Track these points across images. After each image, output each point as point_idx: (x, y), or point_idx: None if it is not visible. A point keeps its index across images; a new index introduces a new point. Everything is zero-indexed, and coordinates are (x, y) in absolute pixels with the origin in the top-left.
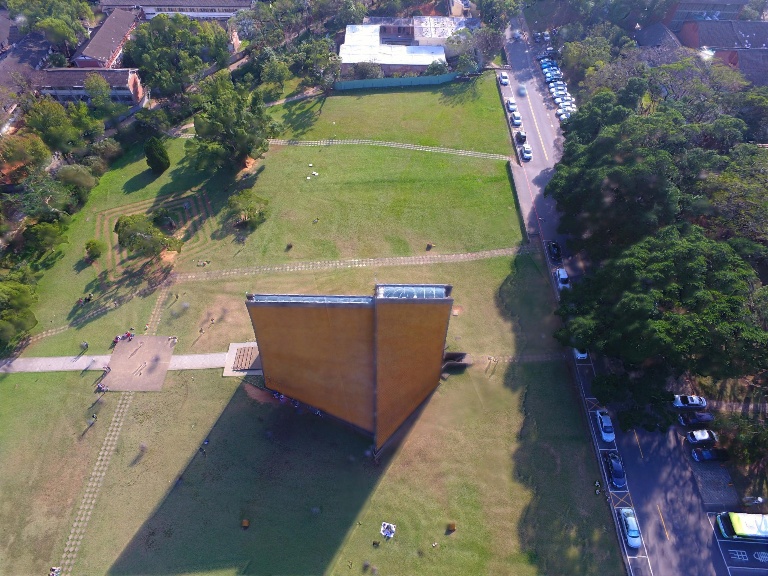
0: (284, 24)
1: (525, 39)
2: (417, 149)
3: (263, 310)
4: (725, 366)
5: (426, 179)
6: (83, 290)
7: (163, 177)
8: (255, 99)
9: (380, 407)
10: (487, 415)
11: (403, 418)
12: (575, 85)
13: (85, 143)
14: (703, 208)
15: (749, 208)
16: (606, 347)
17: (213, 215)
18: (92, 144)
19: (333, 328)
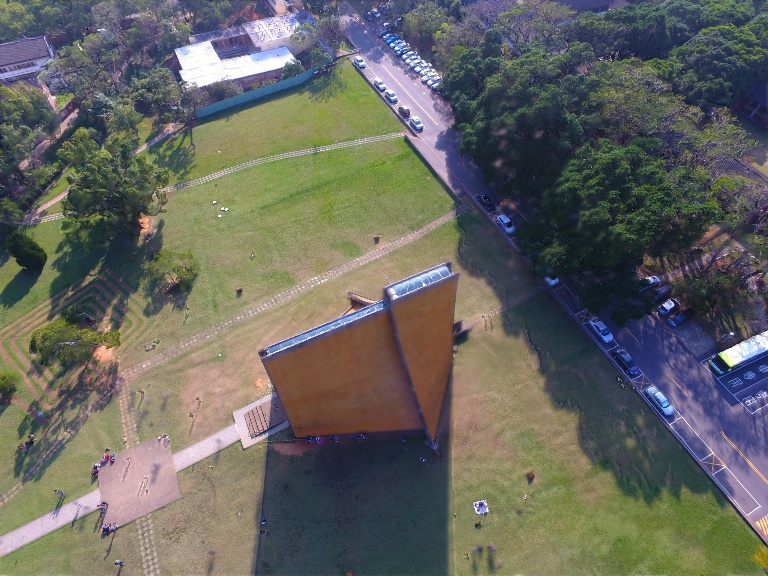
0: (104, 65)
1: (358, 21)
2: (314, 152)
3: (280, 360)
4: (679, 241)
5: (339, 177)
6: (17, 435)
7: (46, 273)
8: (124, 152)
9: (422, 402)
10: (507, 366)
11: (440, 403)
12: (424, 51)
13: None
14: (598, 123)
15: (634, 111)
16: (581, 264)
17: (133, 291)
18: None
19: (353, 348)
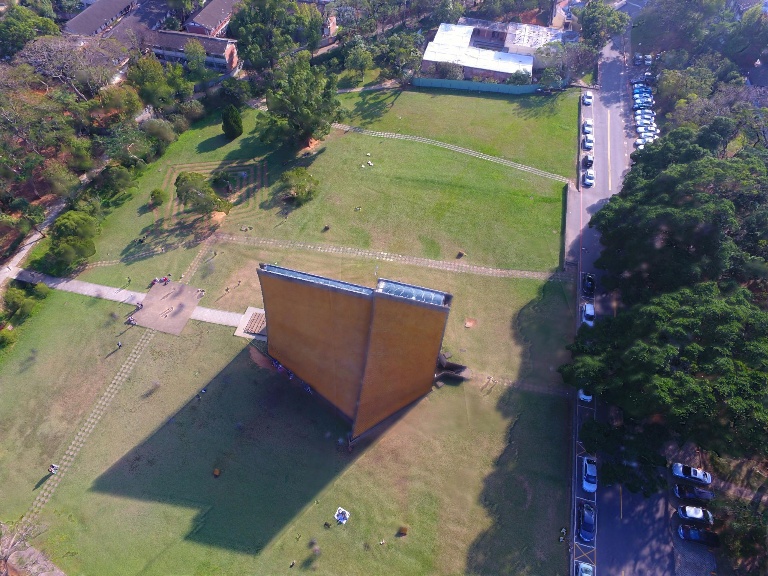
0: (379, 15)
1: (624, 60)
2: (476, 156)
3: (272, 280)
4: (727, 444)
5: (477, 187)
6: (140, 232)
7: (233, 143)
8: (329, 83)
9: (364, 398)
10: (470, 433)
11: (386, 414)
12: (665, 116)
13: (174, 101)
14: (757, 270)
15: None
16: (606, 393)
17: (267, 186)
18: (180, 103)
19: (334, 312)
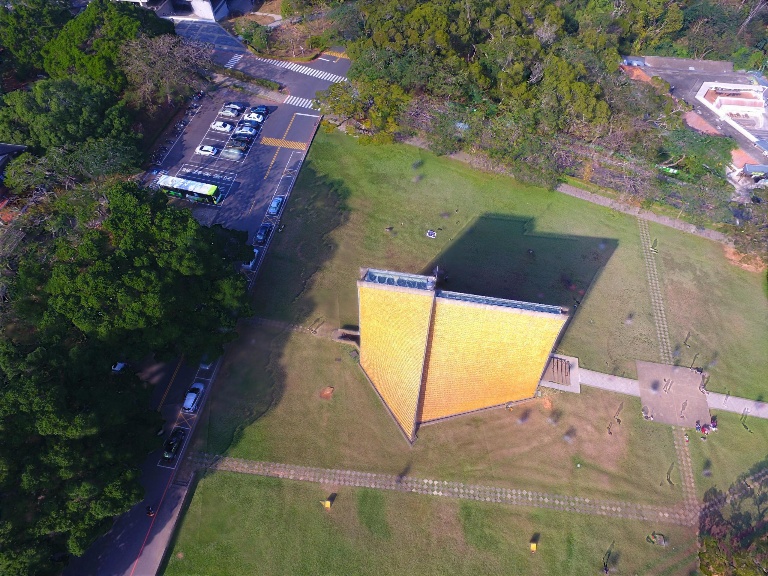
0: None
1: None
2: None
3: None
4: None
5: None
6: None
7: None
8: None
9: None
10: None
11: None
12: None
13: None
14: None
15: None
16: None
17: None
18: None
19: None
